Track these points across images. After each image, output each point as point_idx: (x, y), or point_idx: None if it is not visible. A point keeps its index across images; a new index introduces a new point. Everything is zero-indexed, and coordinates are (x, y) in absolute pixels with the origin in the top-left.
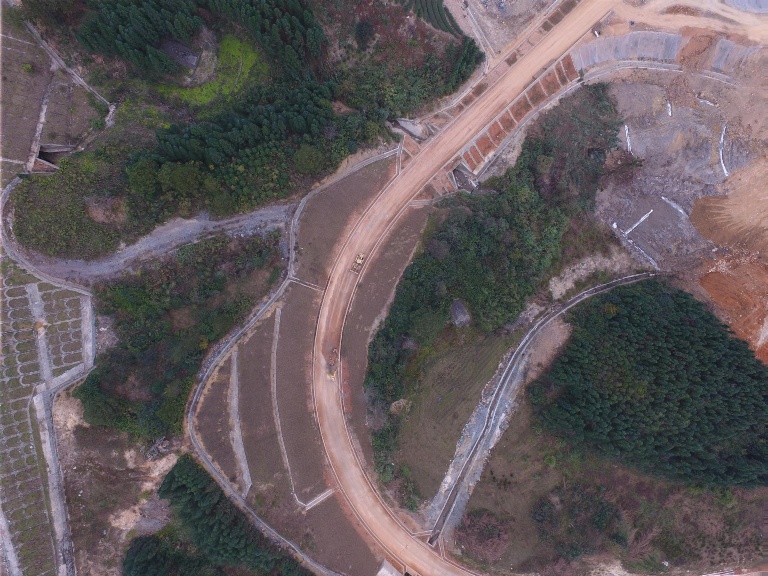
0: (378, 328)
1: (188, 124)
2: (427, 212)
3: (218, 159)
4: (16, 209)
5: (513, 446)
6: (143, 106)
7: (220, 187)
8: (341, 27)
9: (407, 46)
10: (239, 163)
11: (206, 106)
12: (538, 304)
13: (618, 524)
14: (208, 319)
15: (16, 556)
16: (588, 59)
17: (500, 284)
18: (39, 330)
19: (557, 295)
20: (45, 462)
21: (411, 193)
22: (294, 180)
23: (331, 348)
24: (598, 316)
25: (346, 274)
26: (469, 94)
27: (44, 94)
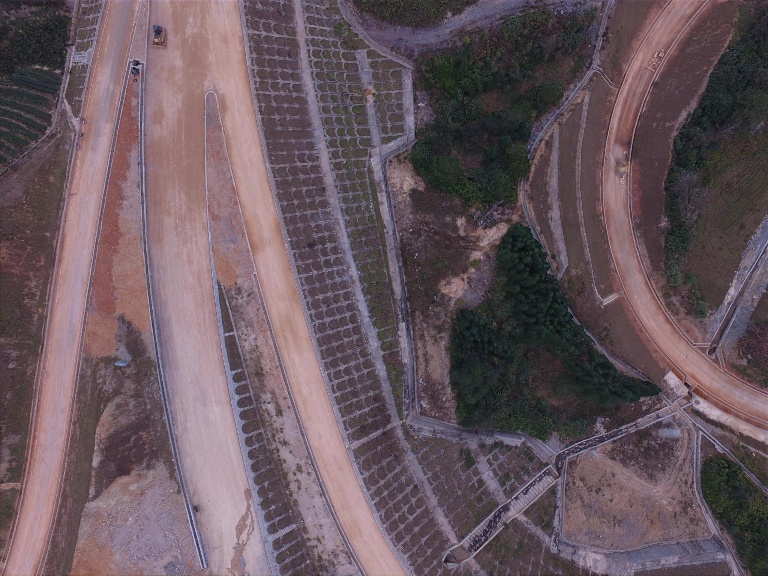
0: (684, 121)
1: None
2: (736, 3)
3: None
4: None
5: None
6: None
7: None
8: None
9: None
10: None
11: None
12: None
13: None
14: (522, 100)
15: (366, 306)
16: None
17: None
18: (368, 97)
19: None
20: (383, 223)
21: None
22: None
23: (622, 149)
24: None
25: (641, 72)
26: None
27: None
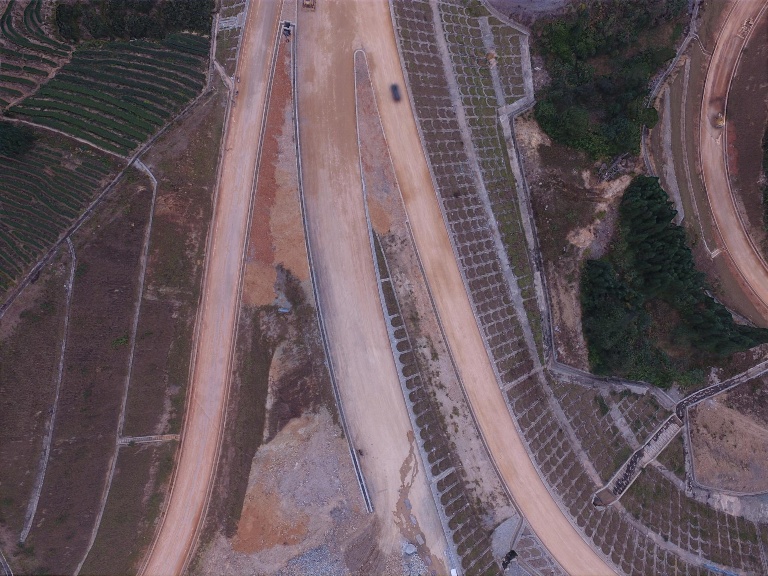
0: None
1: None
2: None
3: None
4: None
5: None
6: None
7: None
8: None
9: None
10: None
11: None
12: None
13: None
14: (630, 64)
15: (506, 255)
16: None
17: None
18: (491, 61)
19: None
20: (513, 177)
21: None
22: None
23: (716, 112)
24: None
25: (731, 40)
26: None
27: None
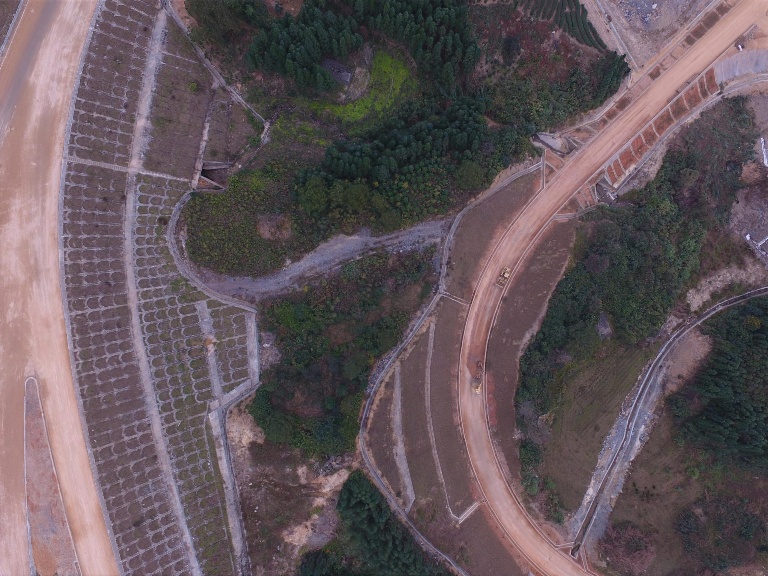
0: (529, 342)
1: (342, 140)
2: (574, 226)
3: (384, 176)
4: (189, 227)
5: (654, 458)
6: (297, 123)
7: (386, 204)
8: (488, 43)
9: (550, 61)
10: (403, 180)
11: (359, 122)
12: (676, 316)
13: (763, 536)
14: (367, 334)
15: (201, 572)
16: (729, 72)
17: (644, 297)
18: (209, 347)
19: (695, 307)
20: (221, 478)
21: (555, 207)
22: (453, 196)
23: (476, 361)
24: (741, 328)
25: (491, 288)
26: (613, 108)
27: (206, 112)
